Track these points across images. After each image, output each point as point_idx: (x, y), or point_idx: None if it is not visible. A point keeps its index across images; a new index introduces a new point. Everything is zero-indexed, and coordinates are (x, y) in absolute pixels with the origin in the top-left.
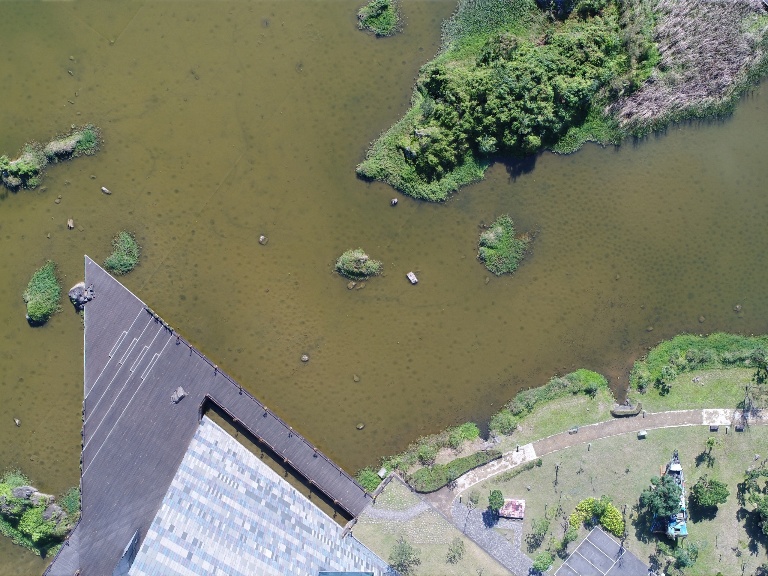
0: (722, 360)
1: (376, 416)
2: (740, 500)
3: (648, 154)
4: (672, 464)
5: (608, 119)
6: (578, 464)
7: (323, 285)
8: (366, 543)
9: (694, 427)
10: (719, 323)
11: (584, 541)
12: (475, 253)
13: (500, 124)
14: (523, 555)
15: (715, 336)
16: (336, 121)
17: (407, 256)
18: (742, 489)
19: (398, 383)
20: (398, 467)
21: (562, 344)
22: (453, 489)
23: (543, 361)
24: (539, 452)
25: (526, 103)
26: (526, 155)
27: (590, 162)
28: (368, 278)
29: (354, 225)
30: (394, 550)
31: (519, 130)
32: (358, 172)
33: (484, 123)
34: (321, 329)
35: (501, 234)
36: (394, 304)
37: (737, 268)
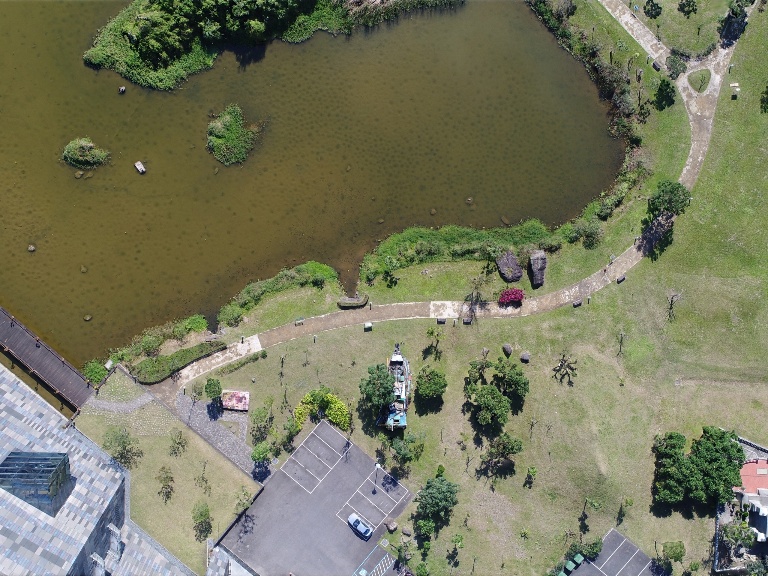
0: (451, 252)
1: (104, 308)
2: (466, 393)
3: (379, 43)
4: (393, 355)
5: (338, 7)
6: (304, 356)
7: (50, 174)
8: (89, 435)
9: (421, 320)
10: (451, 216)
11: (310, 435)
12: (204, 143)
13: (221, 8)
14: (249, 448)
15: (446, 229)
16: (64, 7)
17: (136, 145)
18: (469, 383)
19: (126, 274)
20: None
21: (292, 236)
22: (177, 380)
23: (273, 253)
24: (264, 344)
25: None
26: (256, 43)
27: (321, 51)
28: (95, 167)
29: (82, 113)
30: (107, 438)
31: (234, 12)
32: (84, 59)
33: (203, 6)
34: (48, 219)
35: (229, 123)
36: (122, 194)
37: (469, 160)
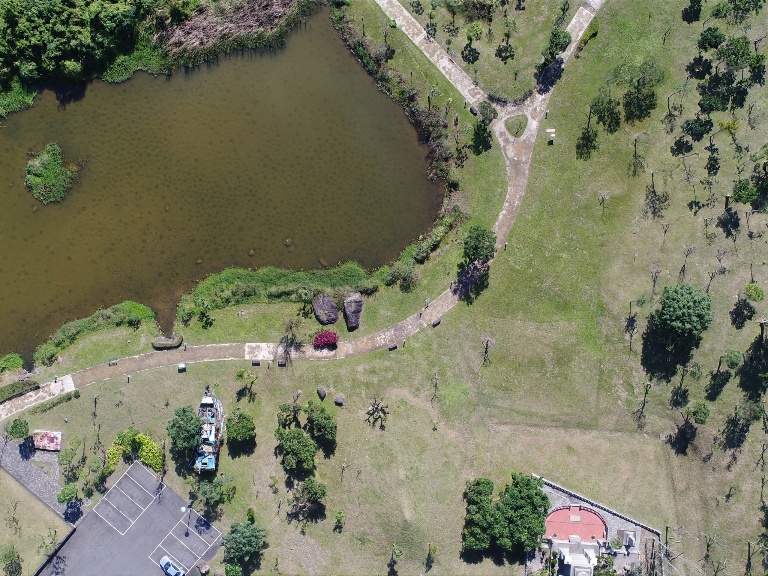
0: (267, 294)
1: None
2: None
3: (200, 84)
4: (203, 397)
5: (158, 48)
6: (117, 397)
7: None
8: None
9: (236, 361)
10: (269, 257)
11: (123, 476)
12: (23, 181)
13: (35, 48)
14: None
15: (264, 270)
16: None
17: None
18: (283, 425)
19: None
20: None
21: (110, 275)
22: None
23: (90, 292)
24: (78, 383)
25: (55, 26)
26: (76, 83)
27: (141, 91)
28: None
29: None
30: None
31: (45, 53)
32: None
33: (17, 46)
34: None
35: (46, 162)
36: None
37: (288, 202)
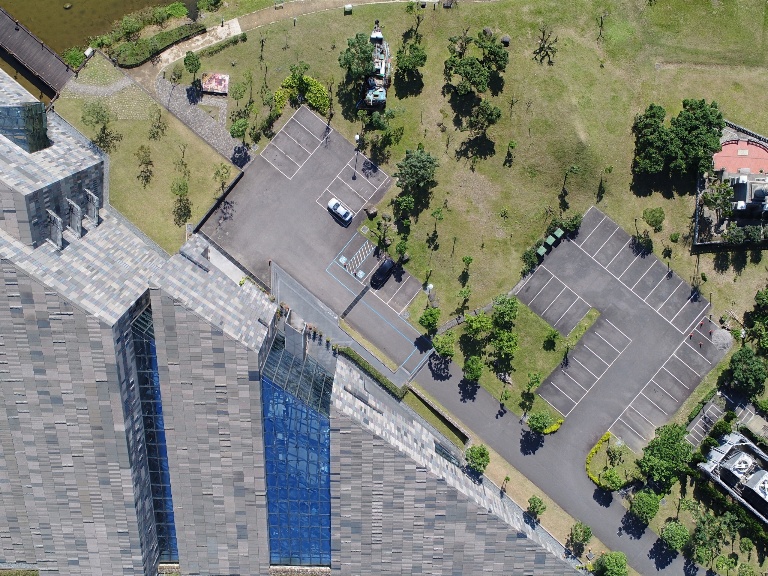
0: None
1: None
2: (446, 76)
3: None
4: (373, 32)
5: None
6: (284, 40)
7: None
8: (68, 118)
9: (401, 3)
10: None
11: (290, 120)
12: None
13: None
14: (228, 133)
15: None
16: None
17: None
18: None
19: None
20: (104, 45)
21: None
22: (157, 64)
23: None
24: (244, 27)
25: None
26: None
27: None
28: None
29: None
30: (86, 110)
31: None
32: None
33: None
34: None
35: None
36: None
37: None
